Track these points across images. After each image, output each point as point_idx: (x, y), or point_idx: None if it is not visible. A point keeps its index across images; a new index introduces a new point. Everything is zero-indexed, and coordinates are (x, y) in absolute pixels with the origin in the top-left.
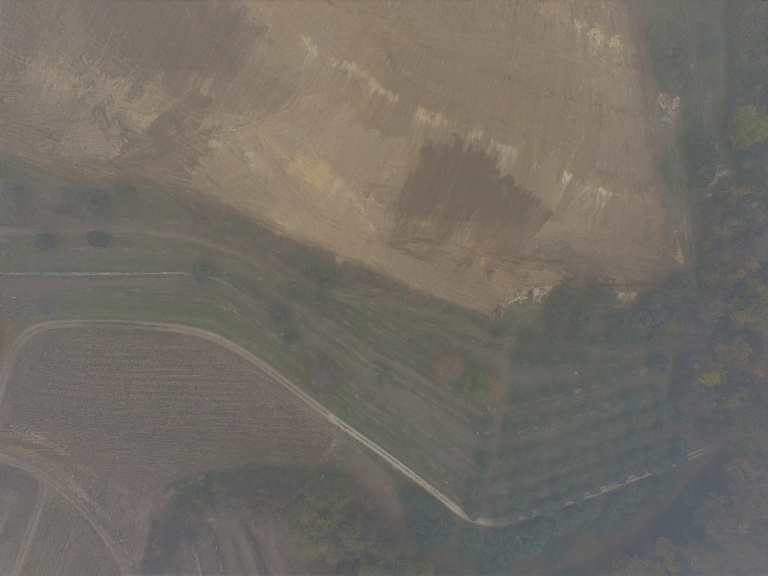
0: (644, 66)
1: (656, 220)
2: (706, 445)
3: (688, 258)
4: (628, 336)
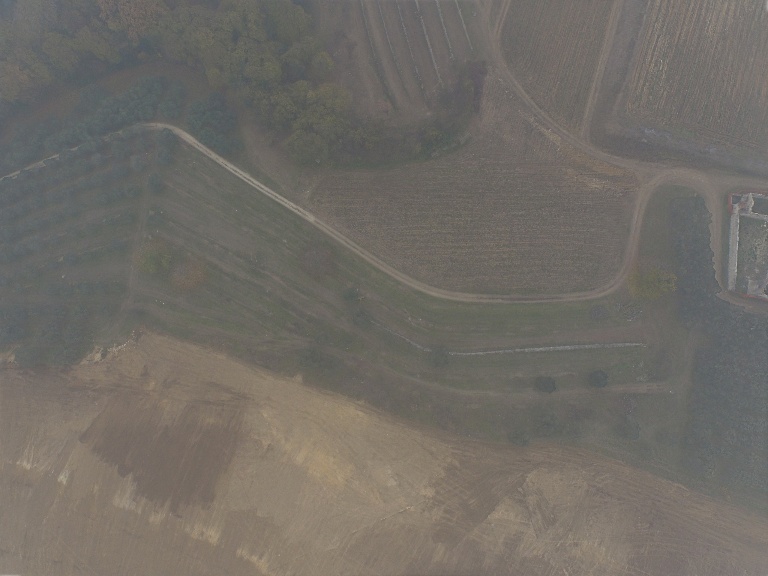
0: None
1: None
2: None
3: None
4: (5, 318)
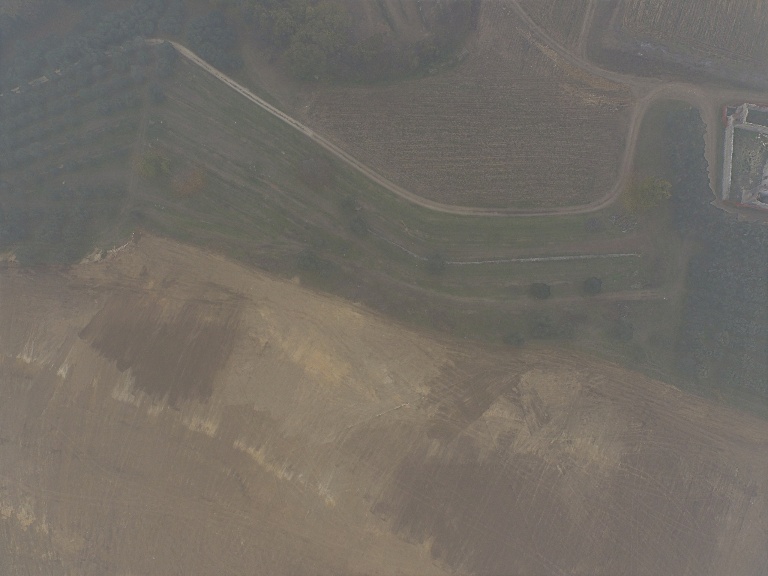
0: None
1: None
2: None
3: None
4: (6, 218)
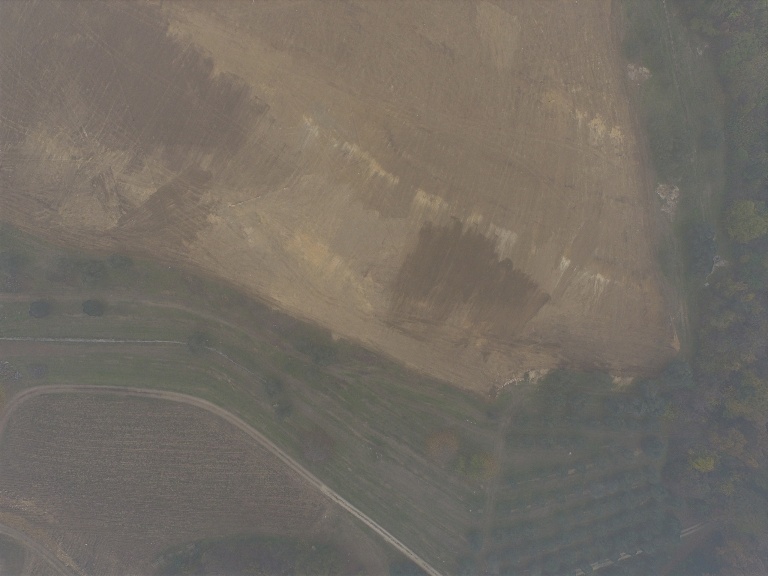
0: (644, 157)
1: (653, 307)
2: (699, 522)
3: (684, 345)
4: (623, 421)
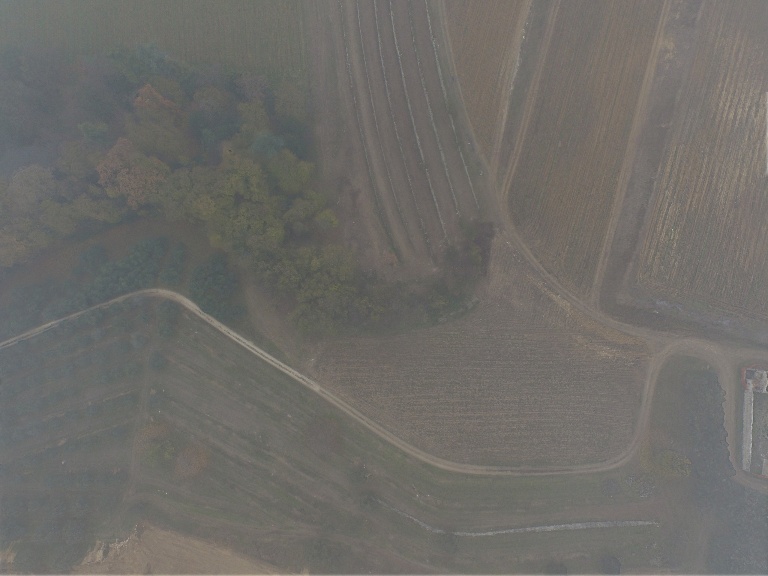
0: None
1: None
2: None
3: None
4: (4, 515)
